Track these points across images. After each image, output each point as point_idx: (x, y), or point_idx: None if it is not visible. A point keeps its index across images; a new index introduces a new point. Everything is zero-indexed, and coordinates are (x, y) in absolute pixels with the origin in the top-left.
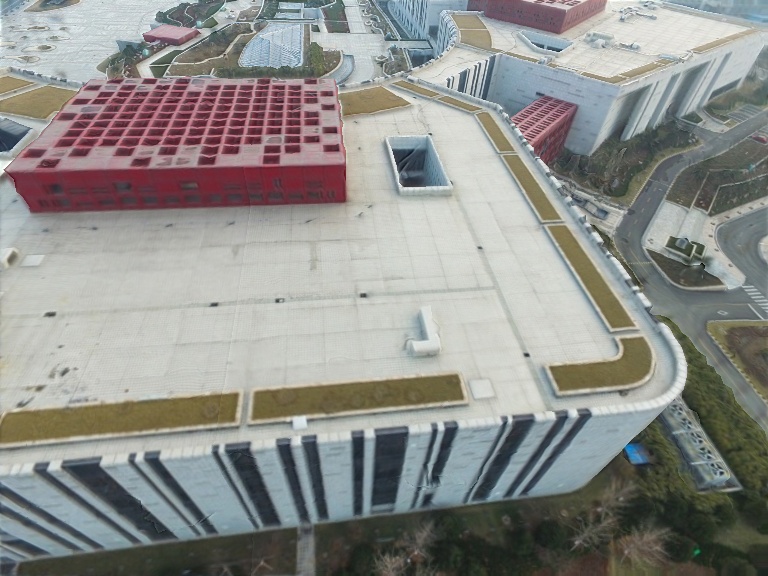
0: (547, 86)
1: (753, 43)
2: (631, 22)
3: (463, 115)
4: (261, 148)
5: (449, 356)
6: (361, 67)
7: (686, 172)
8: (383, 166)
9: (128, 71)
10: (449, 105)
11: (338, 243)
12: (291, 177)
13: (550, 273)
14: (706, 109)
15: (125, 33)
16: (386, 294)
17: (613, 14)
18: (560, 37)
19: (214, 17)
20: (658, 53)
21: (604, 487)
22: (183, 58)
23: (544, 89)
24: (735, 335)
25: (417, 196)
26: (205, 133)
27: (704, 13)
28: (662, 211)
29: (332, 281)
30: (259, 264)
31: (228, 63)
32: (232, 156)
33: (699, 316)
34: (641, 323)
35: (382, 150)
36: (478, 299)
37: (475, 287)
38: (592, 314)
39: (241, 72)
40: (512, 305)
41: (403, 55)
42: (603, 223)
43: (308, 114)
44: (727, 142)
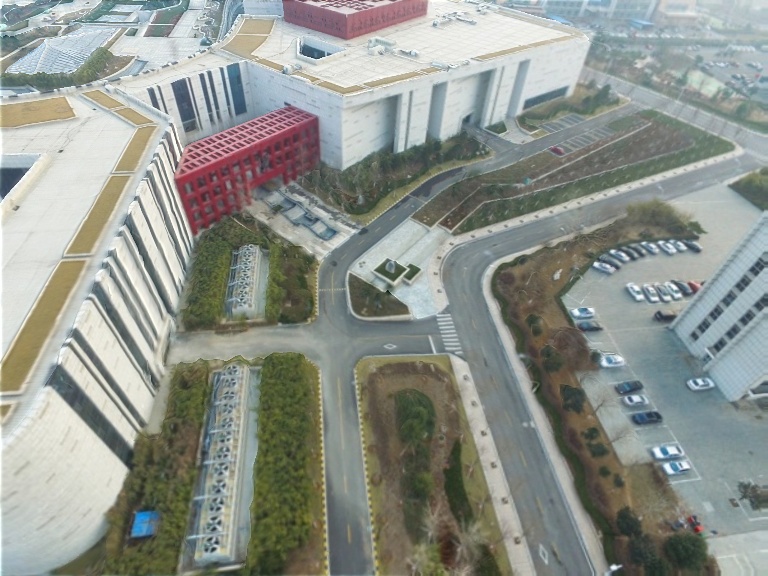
0: (290, 96)
1: (564, 50)
2: (442, 27)
3: (126, 129)
4: None
5: None
6: None
7: None
8: None
9: None
10: (121, 118)
11: None
12: None
13: (1, 321)
14: (518, 119)
15: None
16: None
17: (433, 19)
18: (344, 43)
19: (30, 20)
20: None
21: (86, 566)
22: None
23: (289, 99)
24: (380, 373)
25: None
26: None
27: (535, 18)
28: (399, 230)
29: None
30: None
31: None
32: None
33: (357, 351)
34: (38, 385)
35: None
36: None
37: None
38: None
39: None
40: None
41: None
42: (323, 244)
43: None
44: (519, 154)
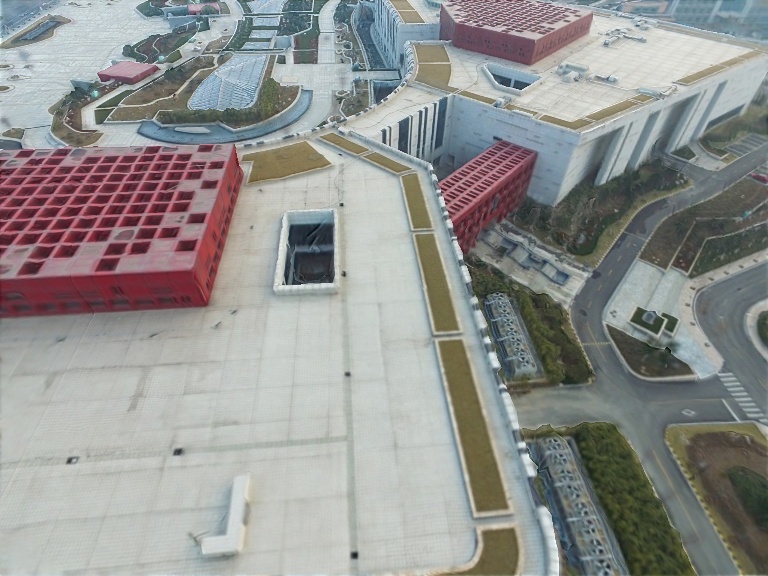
0: (504, 130)
1: (754, 68)
2: (616, 47)
3: (388, 177)
4: (104, 248)
5: (250, 558)
6: (317, 104)
7: (668, 222)
8: (270, 252)
9: (70, 117)
10: (375, 164)
11: (176, 368)
12: (132, 284)
13: (423, 415)
14: (701, 142)
15: (88, 69)
16: (207, 450)
17: (598, 37)
18: (530, 69)
19: (180, 50)
20: (637, 87)
21: None
22: (132, 99)
23: (501, 133)
24: (698, 446)
25: (295, 295)
26: (49, 227)
27: (702, 32)
28: (633, 273)
29: (147, 429)
30: (69, 402)
31: (177, 104)
32: (63, 261)
33: (658, 418)
34: (519, 501)
35: (277, 229)
36: (320, 458)
37: (322, 437)
38: (459, 484)
39: (182, 116)
40: (360, 468)
41: (367, 88)
42: (561, 290)
43: (182, 195)
44: (721, 183)
